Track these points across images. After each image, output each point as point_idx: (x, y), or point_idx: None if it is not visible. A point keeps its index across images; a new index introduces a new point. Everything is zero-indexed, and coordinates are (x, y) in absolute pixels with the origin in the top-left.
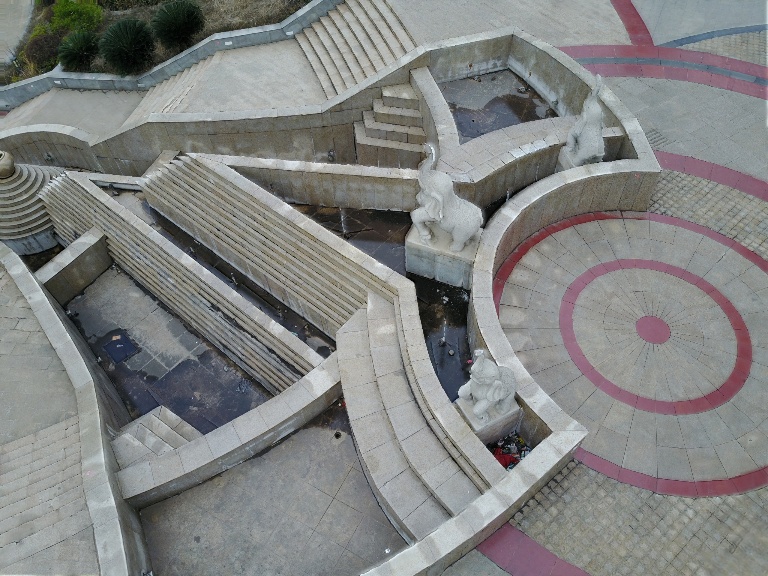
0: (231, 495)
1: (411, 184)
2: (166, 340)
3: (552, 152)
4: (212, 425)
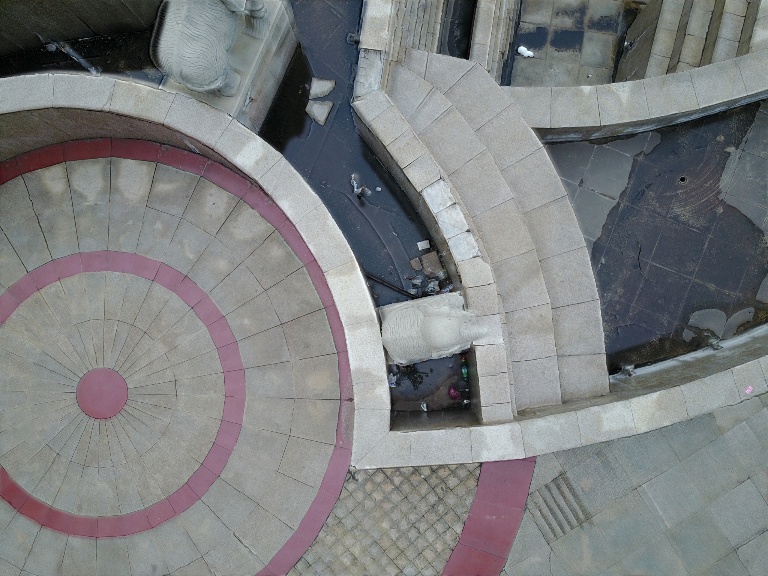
0: None
1: None
2: None
3: None
4: None
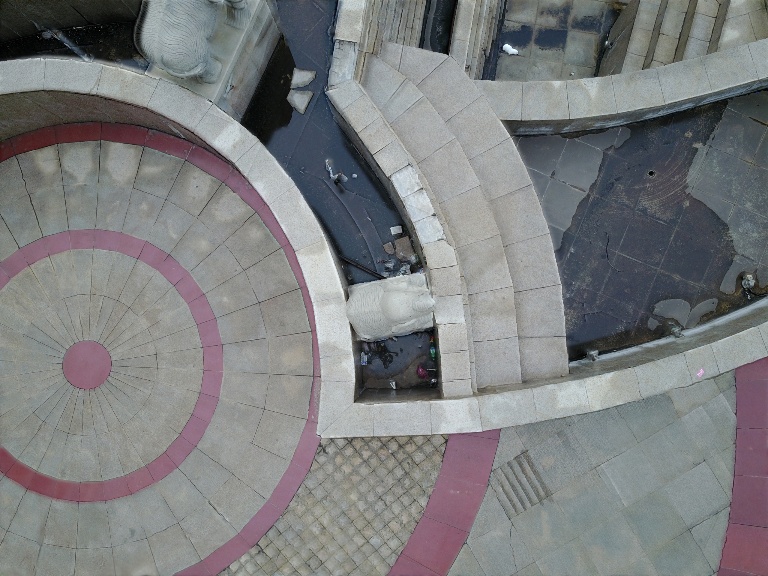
0: None
1: None
2: None
3: None
4: None
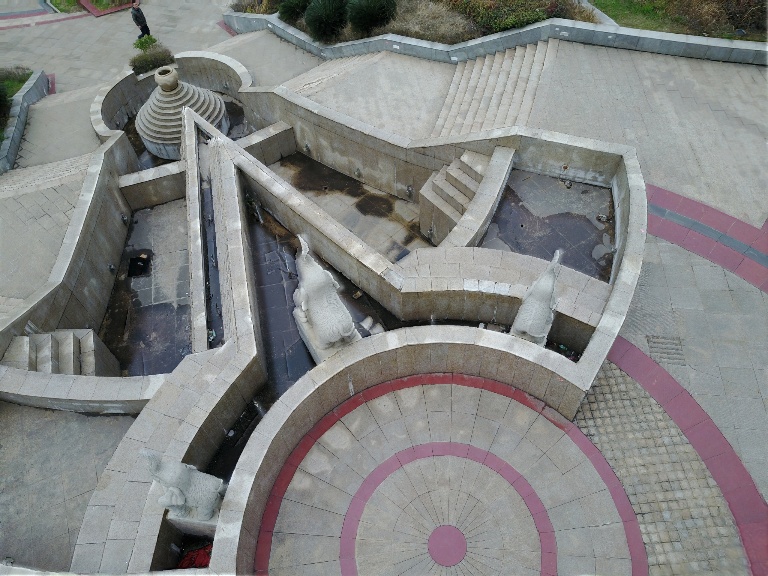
0: (46, 431)
1: (354, 261)
2: (170, 278)
3: (513, 303)
4: (142, 366)
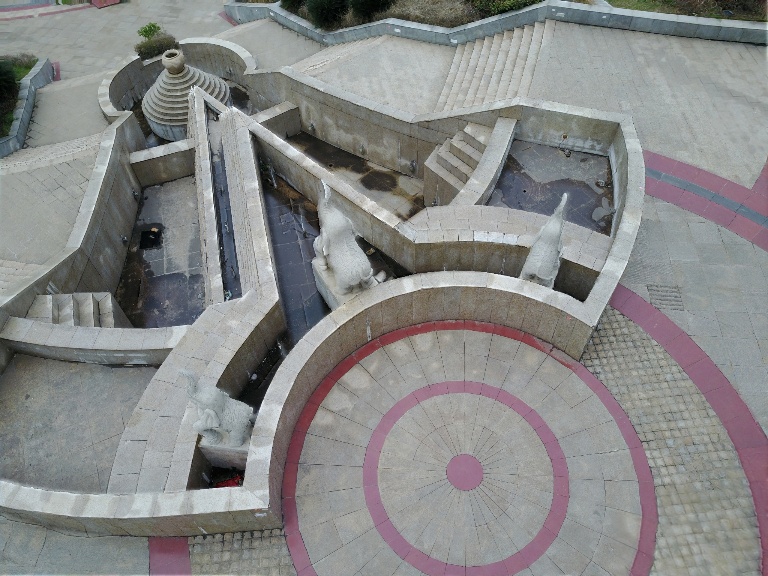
0: (71, 382)
1: (368, 216)
2: (182, 250)
3: (521, 253)
4: None
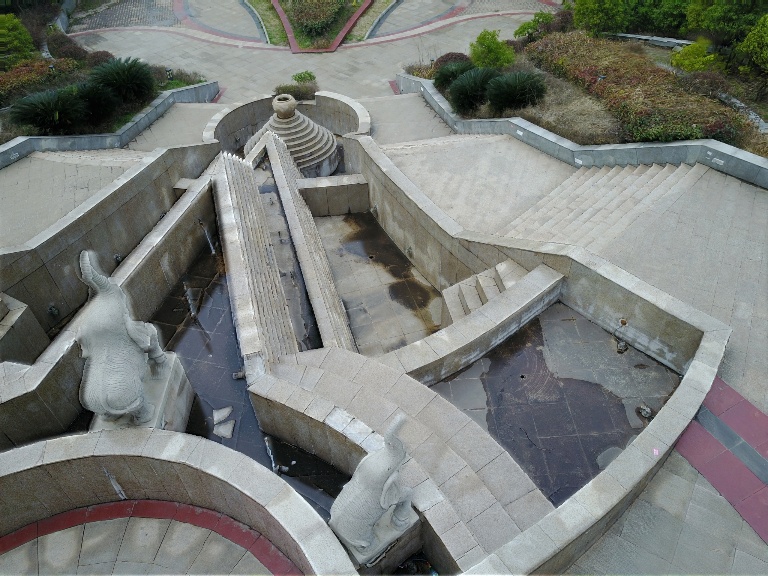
0: None
1: None
2: None
3: None
4: None
